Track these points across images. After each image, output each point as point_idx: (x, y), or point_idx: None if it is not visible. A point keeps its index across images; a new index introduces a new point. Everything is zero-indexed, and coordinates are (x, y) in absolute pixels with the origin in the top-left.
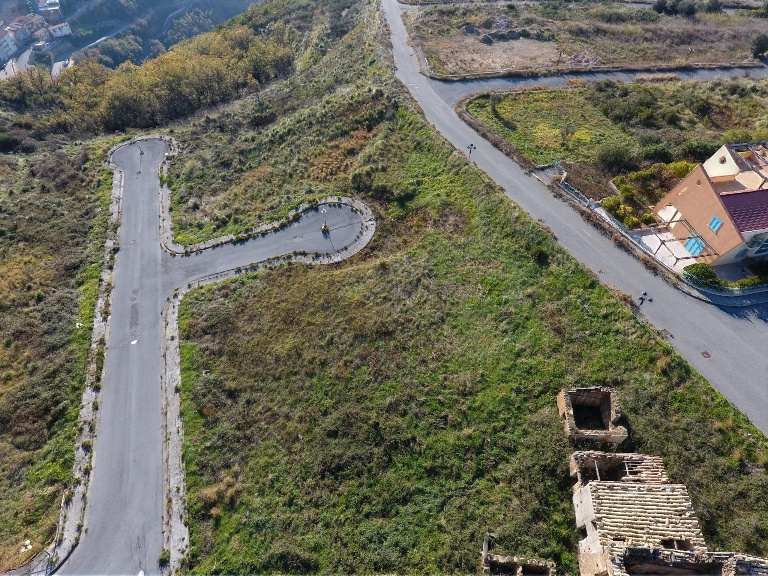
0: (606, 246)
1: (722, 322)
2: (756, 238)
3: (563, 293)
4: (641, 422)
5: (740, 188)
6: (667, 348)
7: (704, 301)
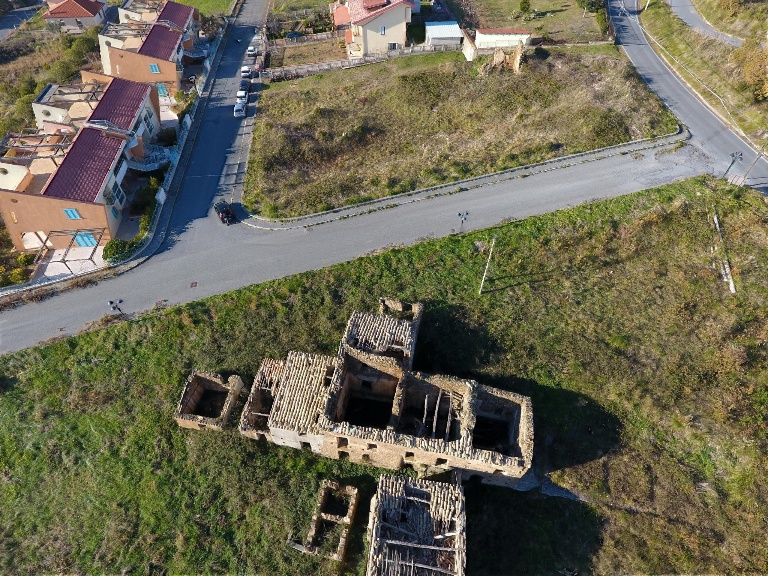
0: (32, 311)
1: (171, 259)
2: (106, 196)
3: (64, 377)
4: (231, 360)
5: (46, 177)
6: (174, 310)
7: (145, 261)
